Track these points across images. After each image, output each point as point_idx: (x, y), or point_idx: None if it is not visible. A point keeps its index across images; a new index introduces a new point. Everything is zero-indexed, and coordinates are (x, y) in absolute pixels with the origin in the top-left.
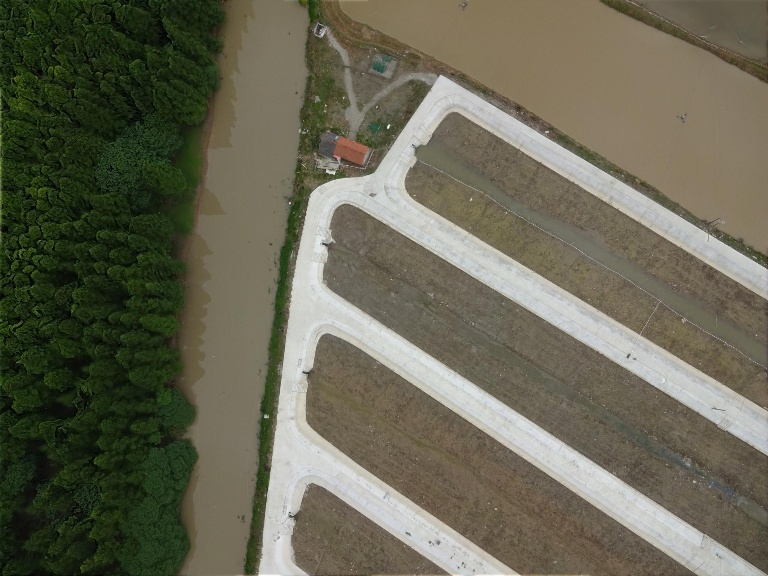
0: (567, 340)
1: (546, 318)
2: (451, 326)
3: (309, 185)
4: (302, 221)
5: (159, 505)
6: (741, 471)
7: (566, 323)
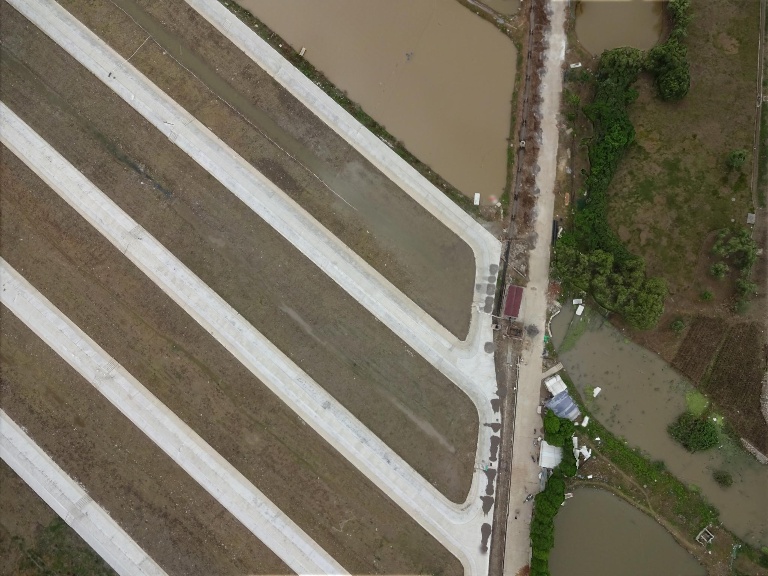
0: (70, 61)
1: (57, 41)
2: None
3: None
4: None
5: None
6: (179, 177)
7: (69, 45)
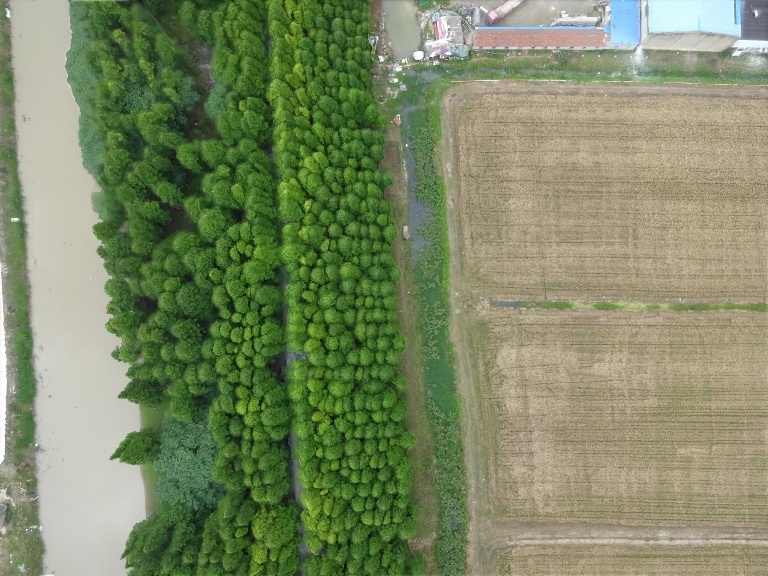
0: None
1: None
2: None
3: (8, 469)
4: (8, 428)
5: (82, 111)
6: None
7: None
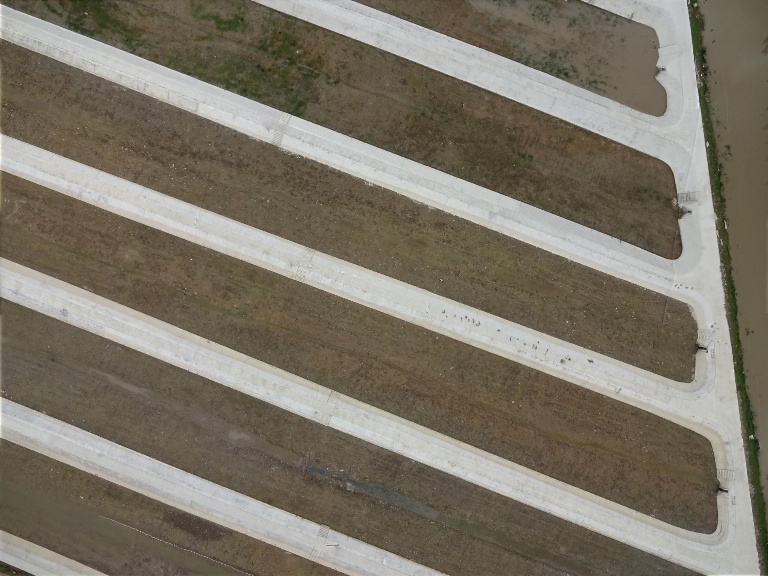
0: None
1: None
2: (589, 568)
3: None
4: None
5: None
6: (304, 490)
7: None
